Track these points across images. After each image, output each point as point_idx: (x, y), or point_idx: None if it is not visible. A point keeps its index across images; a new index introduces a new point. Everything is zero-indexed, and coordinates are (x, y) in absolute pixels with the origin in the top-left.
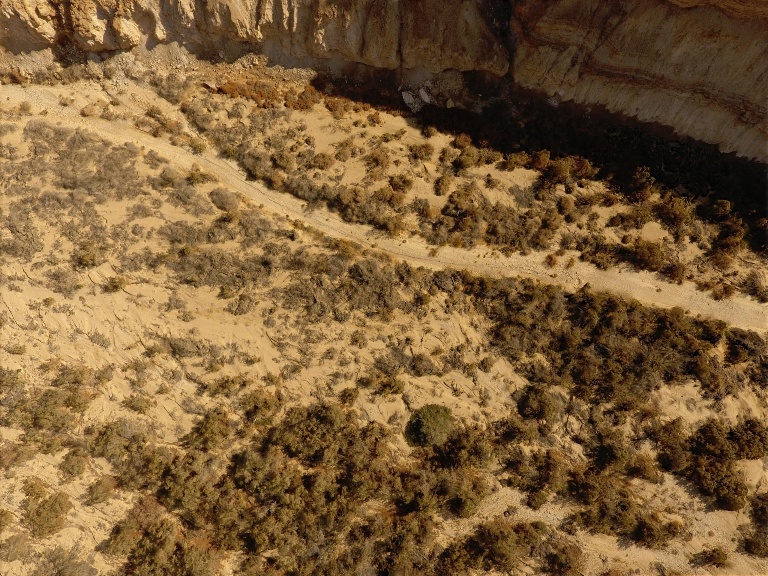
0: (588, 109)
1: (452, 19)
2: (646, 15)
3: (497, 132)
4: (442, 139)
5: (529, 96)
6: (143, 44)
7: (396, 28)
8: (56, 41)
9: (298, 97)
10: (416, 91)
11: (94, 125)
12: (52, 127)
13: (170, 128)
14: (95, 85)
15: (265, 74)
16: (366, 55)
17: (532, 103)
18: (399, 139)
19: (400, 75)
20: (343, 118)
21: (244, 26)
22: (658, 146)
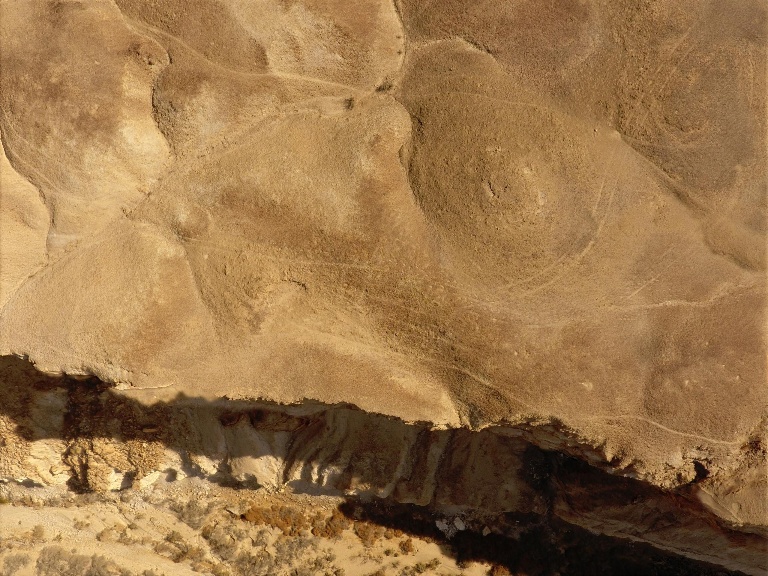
0: (632, 540)
1: (492, 492)
2: (702, 529)
3: (536, 565)
4: (478, 569)
5: (570, 525)
6: (162, 478)
7: (432, 490)
8: (71, 477)
9: (326, 523)
10: (450, 518)
11: (111, 550)
12: (67, 558)
13: (191, 555)
14: (111, 507)
15: (291, 499)
16: (399, 502)
17: (573, 531)
18: (433, 569)
19: (433, 504)
20: (374, 546)
21: (270, 484)
22: (706, 575)
